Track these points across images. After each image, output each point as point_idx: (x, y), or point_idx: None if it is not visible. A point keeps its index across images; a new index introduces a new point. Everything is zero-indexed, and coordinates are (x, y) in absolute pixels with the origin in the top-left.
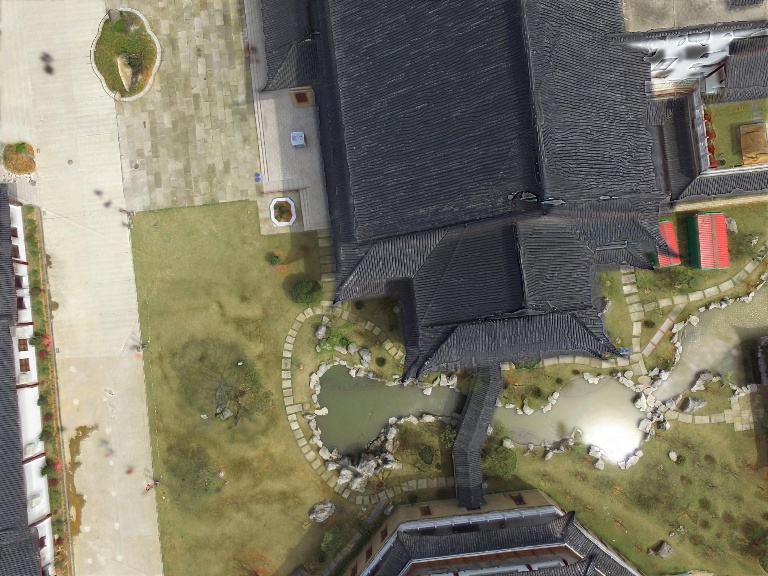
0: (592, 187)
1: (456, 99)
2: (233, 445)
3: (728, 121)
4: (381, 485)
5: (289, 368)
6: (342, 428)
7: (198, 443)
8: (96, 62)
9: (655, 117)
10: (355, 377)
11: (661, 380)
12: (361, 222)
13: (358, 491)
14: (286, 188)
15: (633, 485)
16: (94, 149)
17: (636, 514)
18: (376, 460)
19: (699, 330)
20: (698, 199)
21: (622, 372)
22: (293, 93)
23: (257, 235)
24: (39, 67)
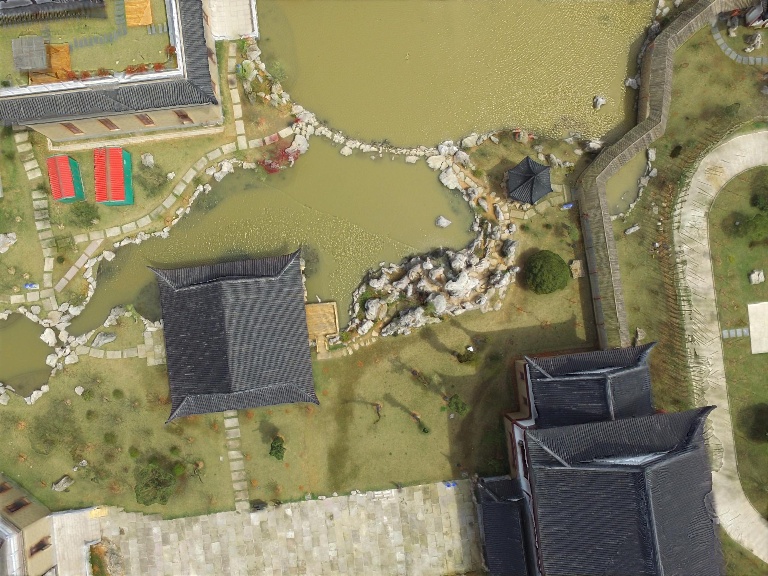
0: None
1: None
2: None
3: None
4: None
5: None
6: None
7: None
8: None
9: None
10: None
11: (70, 315)
12: None
13: None
14: None
15: (39, 420)
16: None
17: None
18: None
19: (117, 266)
20: (115, 135)
21: (30, 307)
22: None
23: None
24: None
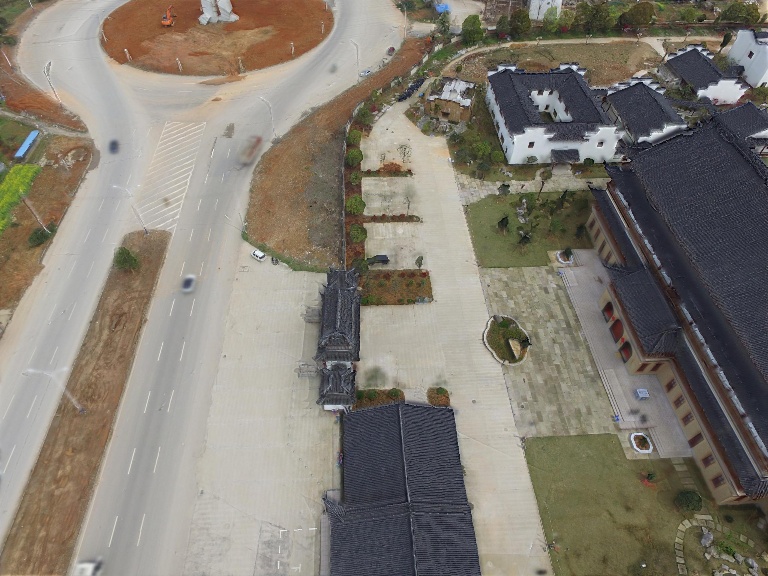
0: None
1: None
2: None
3: None
4: None
5: (686, 574)
6: None
7: None
8: (488, 342)
9: None
10: None
11: None
12: None
13: None
14: (638, 427)
15: None
16: (490, 394)
17: None
18: None
19: None
20: None
21: None
22: (641, 364)
23: (624, 459)
24: (448, 344)
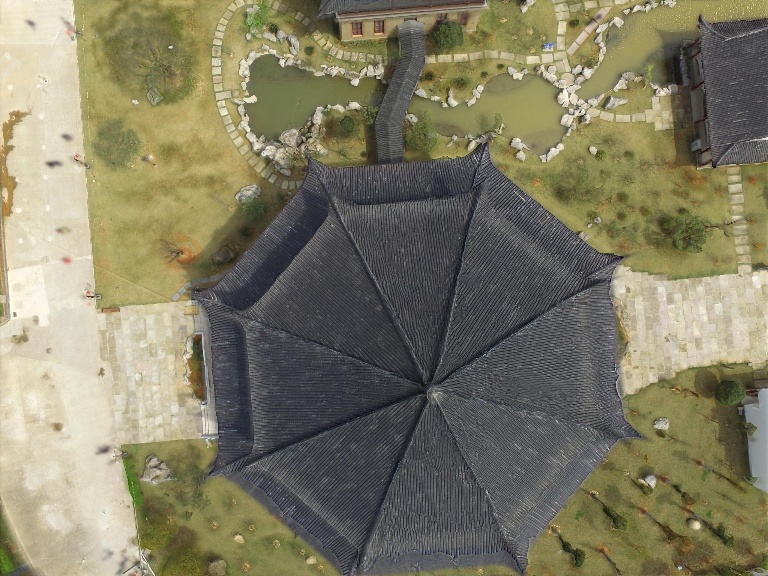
0: None
1: None
2: (163, 130)
3: None
4: (306, 168)
5: (219, 56)
6: (270, 118)
7: (129, 128)
8: None
9: None
10: (284, 67)
11: (584, 77)
12: None
13: (284, 175)
14: None
15: (553, 177)
16: None
17: (555, 205)
18: (300, 137)
19: (623, 33)
20: None
21: (546, 68)
22: None
23: None
24: None
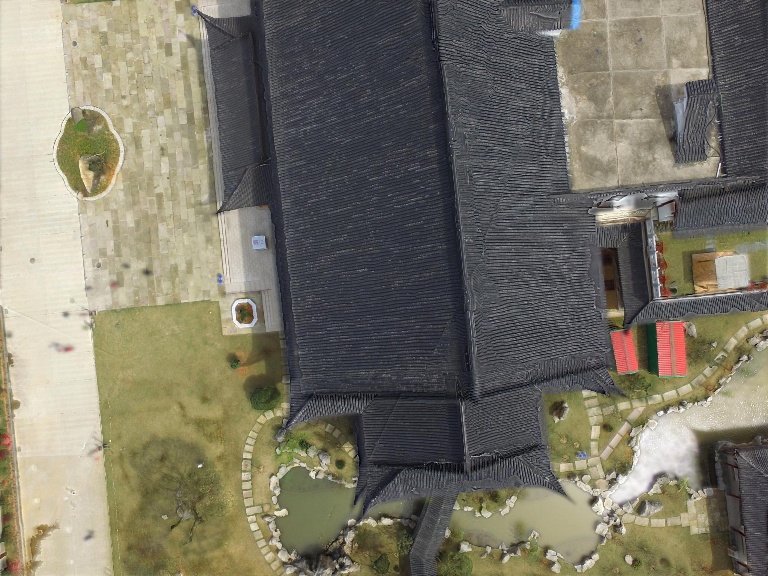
0: (528, 360)
1: (394, 270)
2: (193, 545)
3: (680, 249)
4: None
5: (249, 470)
6: (302, 529)
7: (158, 543)
8: (58, 161)
9: (609, 240)
10: (315, 479)
11: (618, 484)
12: (305, 373)
13: None
14: (248, 289)
15: None
16: (56, 248)
17: None
18: (334, 565)
19: (657, 433)
20: None
21: (580, 476)
22: None
23: (219, 336)
24: (1, 164)
